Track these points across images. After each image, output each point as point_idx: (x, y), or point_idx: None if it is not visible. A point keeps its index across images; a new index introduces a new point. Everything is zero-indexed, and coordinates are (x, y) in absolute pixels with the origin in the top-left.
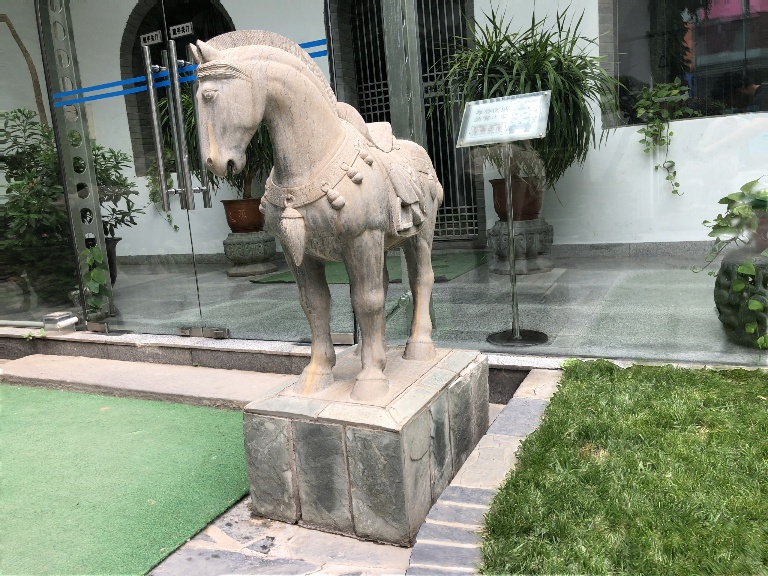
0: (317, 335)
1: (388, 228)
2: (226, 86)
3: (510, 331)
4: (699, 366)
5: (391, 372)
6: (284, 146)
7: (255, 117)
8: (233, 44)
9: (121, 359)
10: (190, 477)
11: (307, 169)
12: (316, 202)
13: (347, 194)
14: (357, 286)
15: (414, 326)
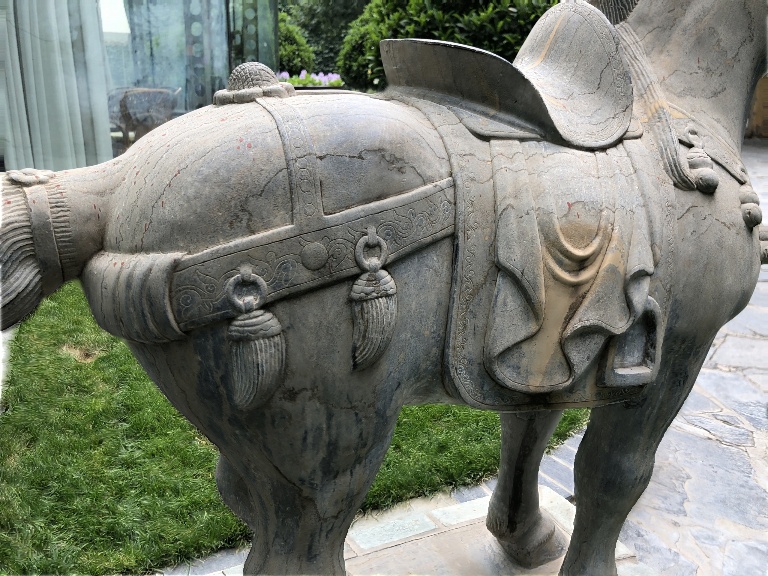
0: None
1: None
2: None
3: None
4: None
5: (447, 575)
6: None
7: None
8: None
9: None
10: None
11: None
12: None
13: None
14: None
15: None
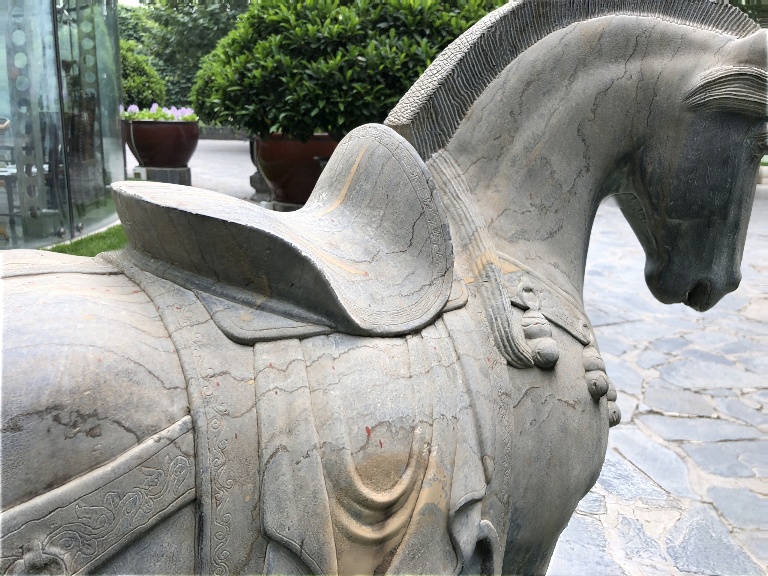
0: None
1: None
2: None
3: None
4: None
5: None
6: None
7: None
8: None
9: None
10: None
11: None
12: None
13: None
14: None
15: None
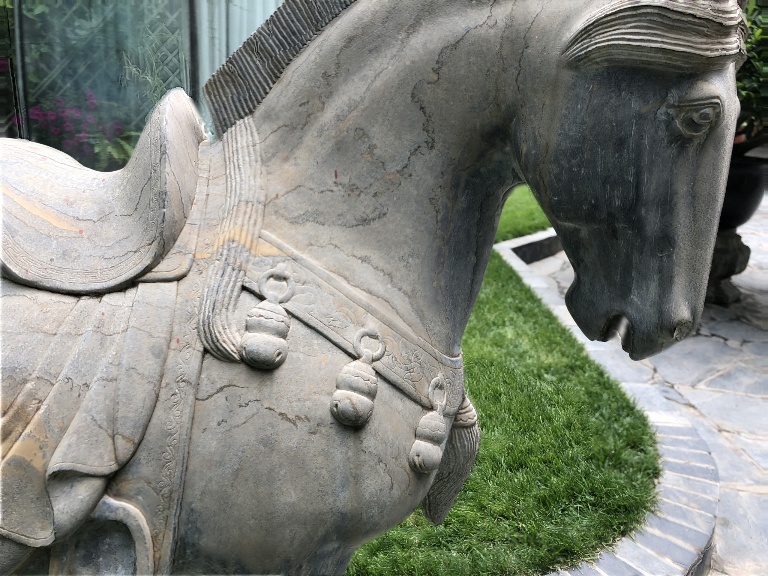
0: None
1: None
2: None
3: None
4: None
5: None
6: None
7: None
8: None
9: None
10: None
11: None
12: None
13: None
14: None
15: None
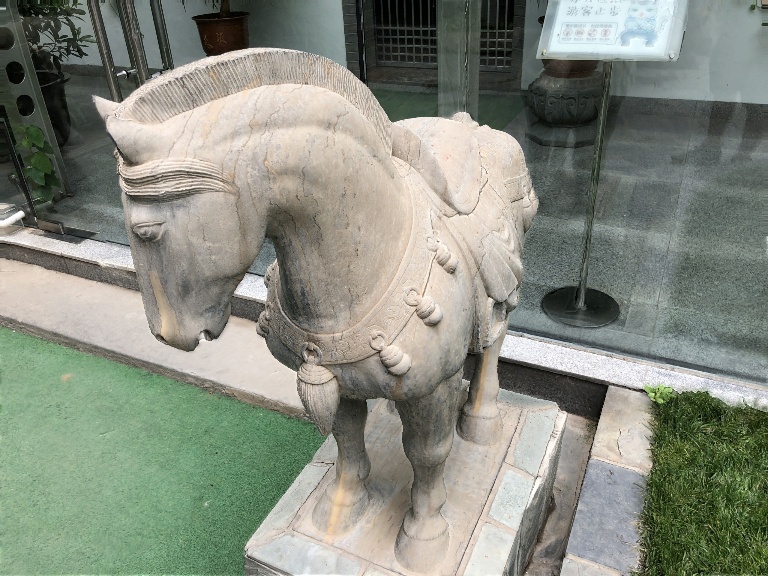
0: (347, 456)
1: (469, 344)
2: (182, 212)
3: (570, 289)
4: None
5: (446, 479)
6: (303, 276)
7: (246, 255)
8: (190, 102)
9: (83, 276)
10: (178, 548)
11: (345, 308)
12: (360, 362)
13: (415, 348)
14: (416, 439)
15: (476, 391)
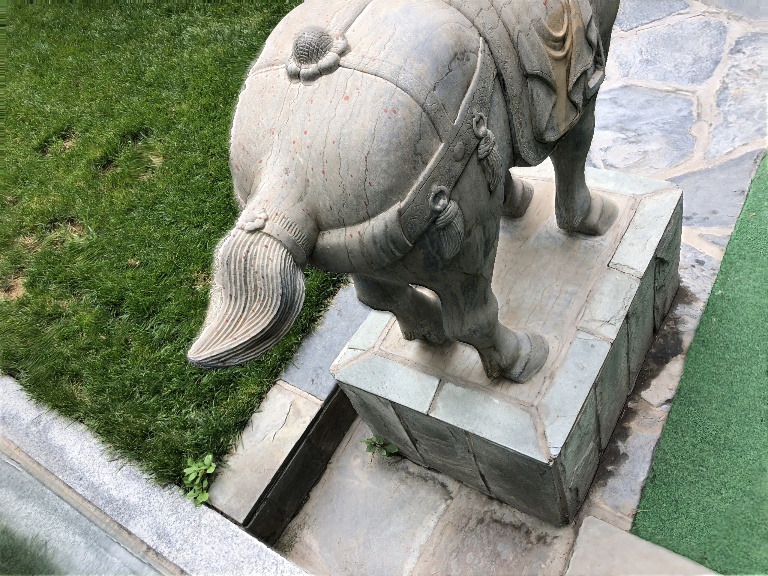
0: None
1: None
2: None
3: None
4: (47, 474)
5: None
6: None
7: None
8: None
9: None
10: None
11: None
12: None
13: None
14: None
15: None
